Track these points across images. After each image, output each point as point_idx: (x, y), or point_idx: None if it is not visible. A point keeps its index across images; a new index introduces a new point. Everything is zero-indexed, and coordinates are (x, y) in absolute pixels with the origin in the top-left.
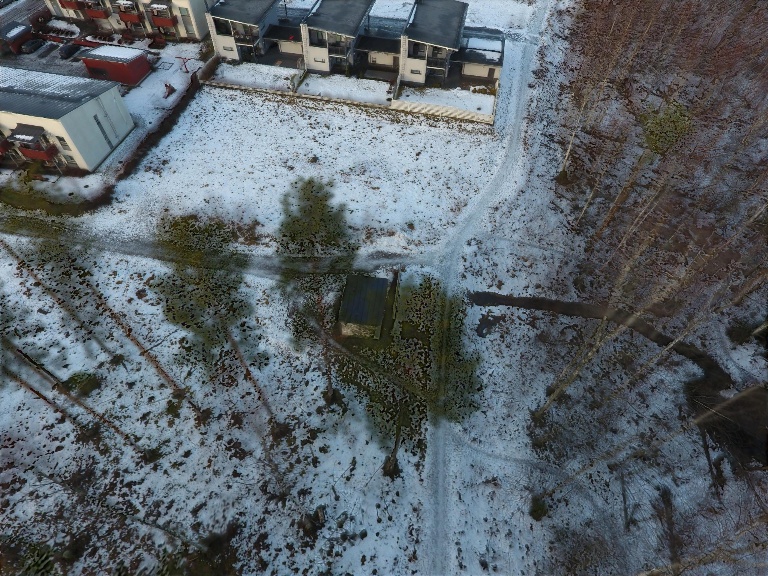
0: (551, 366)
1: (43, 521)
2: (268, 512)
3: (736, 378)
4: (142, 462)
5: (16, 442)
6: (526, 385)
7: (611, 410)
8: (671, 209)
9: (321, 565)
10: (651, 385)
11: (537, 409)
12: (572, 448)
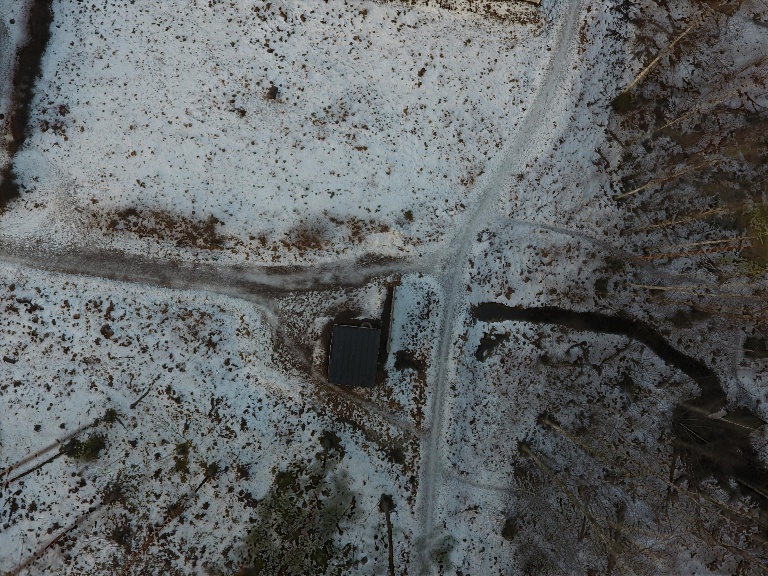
0: (548, 392)
1: (105, 569)
2: (285, 549)
3: (732, 398)
4: (169, 517)
5: (51, 505)
6: (519, 415)
7: (596, 436)
8: (754, 154)
9: None
10: (643, 408)
11: (525, 440)
12: (550, 476)
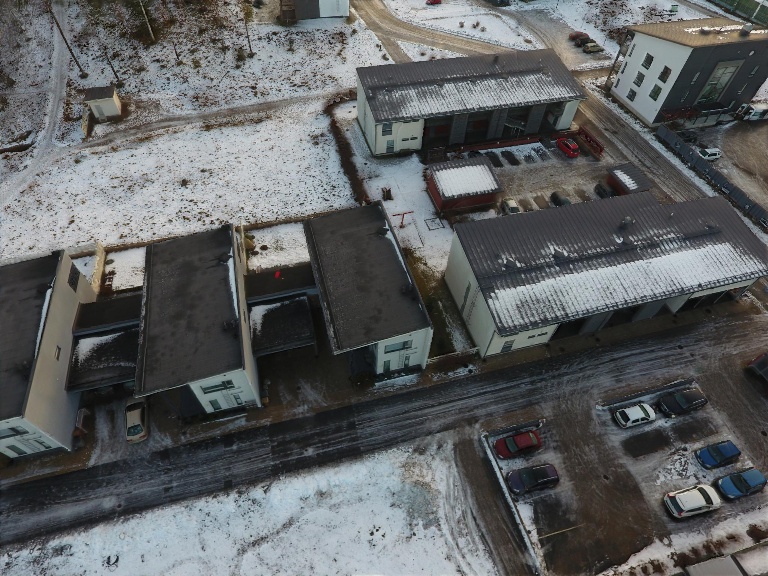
0: None
1: None
2: None
3: None
4: (196, 49)
5: (252, 41)
6: (3, 119)
7: None
8: None
9: (109, 50)
10: None
11: None
12: None
